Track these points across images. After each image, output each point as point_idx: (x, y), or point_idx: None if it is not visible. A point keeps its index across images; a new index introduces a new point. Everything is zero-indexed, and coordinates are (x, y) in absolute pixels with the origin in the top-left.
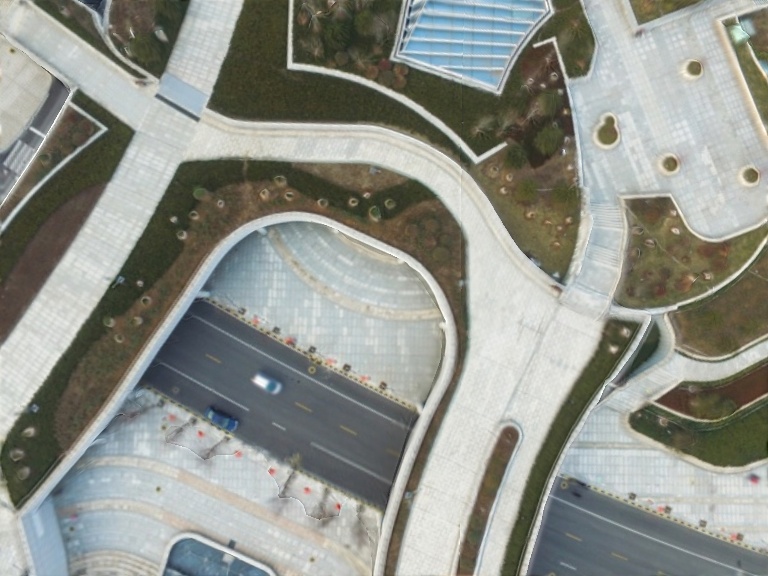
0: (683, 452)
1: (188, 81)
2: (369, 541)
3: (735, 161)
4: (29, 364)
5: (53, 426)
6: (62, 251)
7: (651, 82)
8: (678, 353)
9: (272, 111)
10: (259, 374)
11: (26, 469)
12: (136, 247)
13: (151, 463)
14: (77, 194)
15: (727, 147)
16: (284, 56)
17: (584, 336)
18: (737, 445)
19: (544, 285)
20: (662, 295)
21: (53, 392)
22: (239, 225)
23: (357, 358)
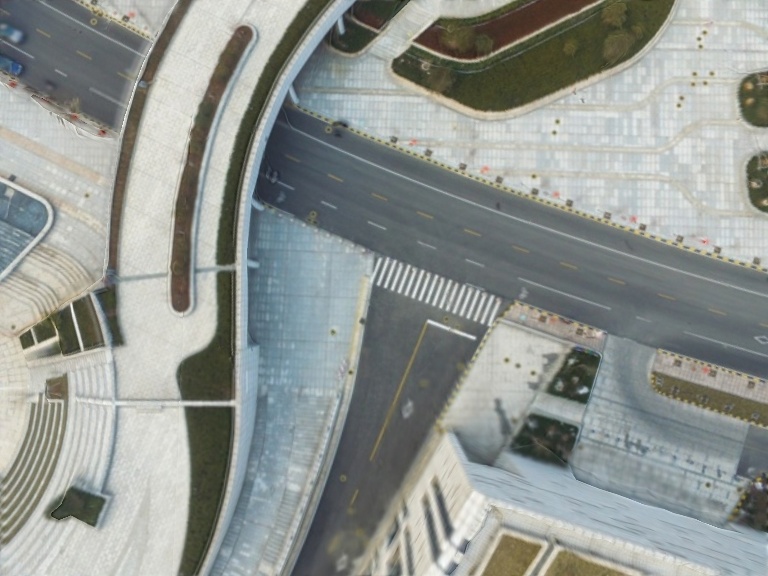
0: (444, 95)
1: None
2: None
3: None
4: None
5: None
6: None
7: None
8: None
9: None
10: (44, 25)
11: None
12: None
13: None
14: None
15: None
16: None
17: None
18: (497, 88)
19: None
20: None
21: None
22: None
23: (135, 10)
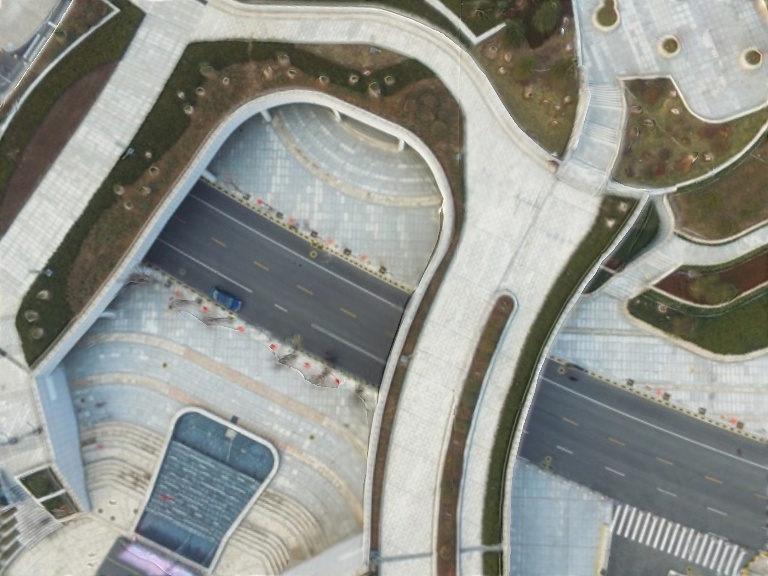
0: (682, 338)
1: None
2: None
3: (737, 44)
4: (44, 231)
5: (66, 290)
6: (76, 124)
7: None
8: (677, 236)
9: None
10: (262, 257)
11: (40, 330)
12: (145, 121)
13: (158, 340)
14: (91, 71)
15: (729, 30)
16: None
17: (581, 211)
18: (738, 332)
19: (541, 161)
20: (661, 175)
21: (66, 257)
22: (244, 102)
23: (357, 243)
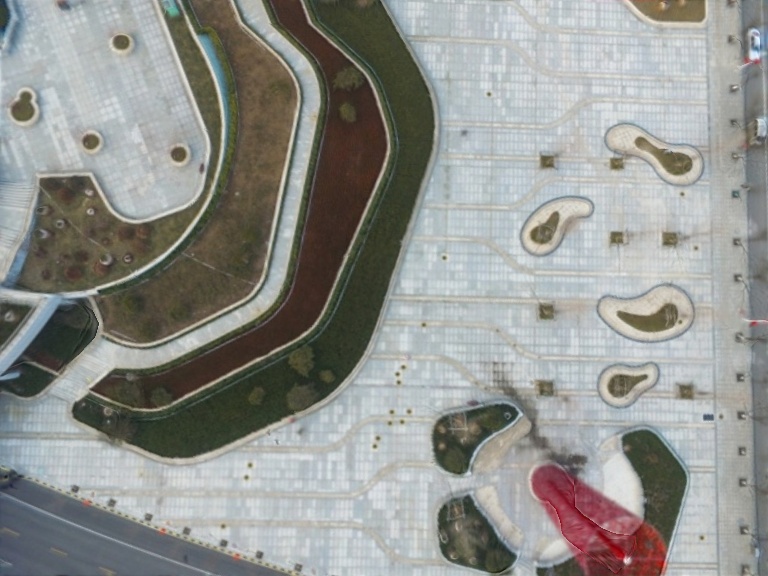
0: (127, 442)
1: None
2: None
3: (168, 139)
4: None
5: None
6: None
7: (79, 57)
8: (106, 339)
9: None
10: None
11: None
12: None
13: None
14: None
15: (160, 125)
16: None
17: None
18: (183, 435)
19: None
20: (77, 278)
21: None
22: None
23: None
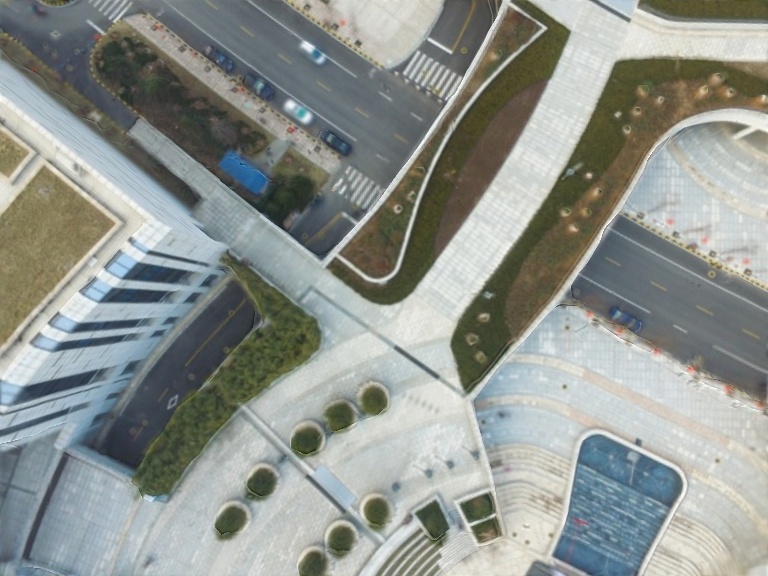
0: None
1: None
2: None
3: None
4: (480, 253)
5: (504, 313)
6: (511, 144)
7: None
8: None
9: (703, 11)
10: (659, 277)
11: (481, 353)
12: (581, 141)
13: (556, 361)
14: (522, 90)
15: None
16: None
17: None
18: None
19: None
20: None
21: (506, 280)
22: (676, 122)
23: (758, 263)
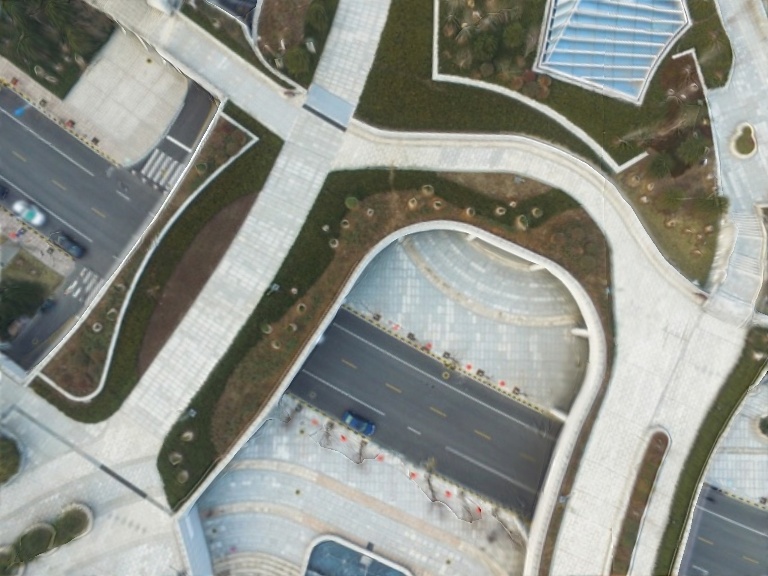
0: None
1: (334, 92)
2: (504, 544)
3: None
4: (186, 370)
5: (210, 430)
6: (217, 259)
7: None
8: None
9: (417, 121)
10: (394, 379)
11: (184, 473)
12: (289, 255)
13: (290, 466)
14: (231, 203)
15: None
16: (429, 67)
17: (727, 343)
18: None
19: (687, 293)
20: None
21: (210, 397)
22: (387, 233)
23: (490, 364)
